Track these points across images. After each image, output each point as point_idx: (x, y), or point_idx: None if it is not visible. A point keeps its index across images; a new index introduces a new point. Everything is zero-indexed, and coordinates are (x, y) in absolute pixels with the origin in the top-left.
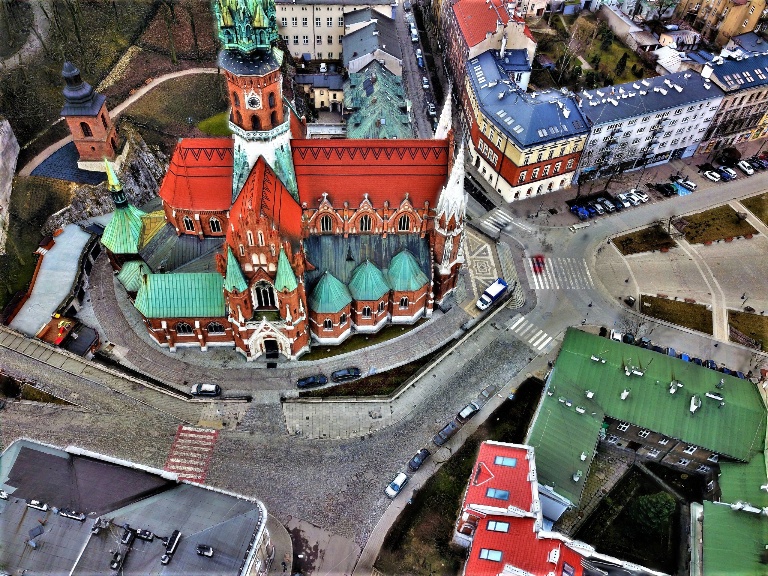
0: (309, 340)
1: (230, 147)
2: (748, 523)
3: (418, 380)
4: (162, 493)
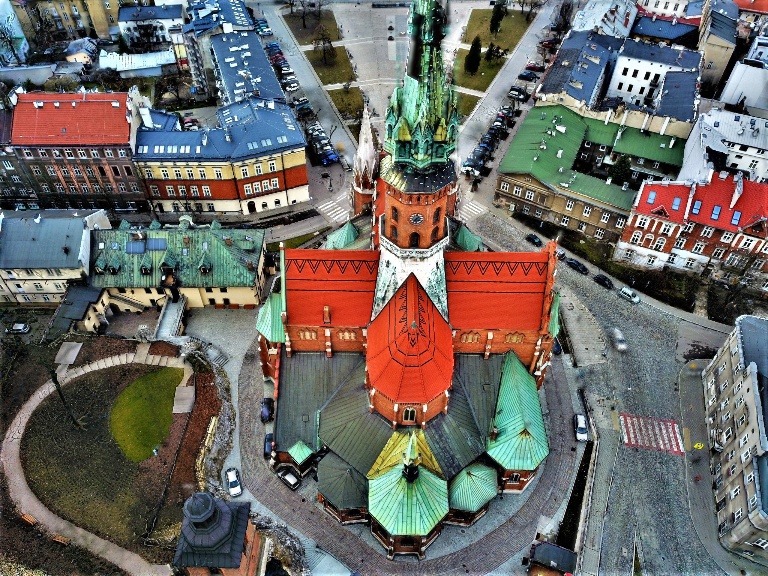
0: None
1: (416, 284)
2: (627, 135)
3: None
4: (765, 376)
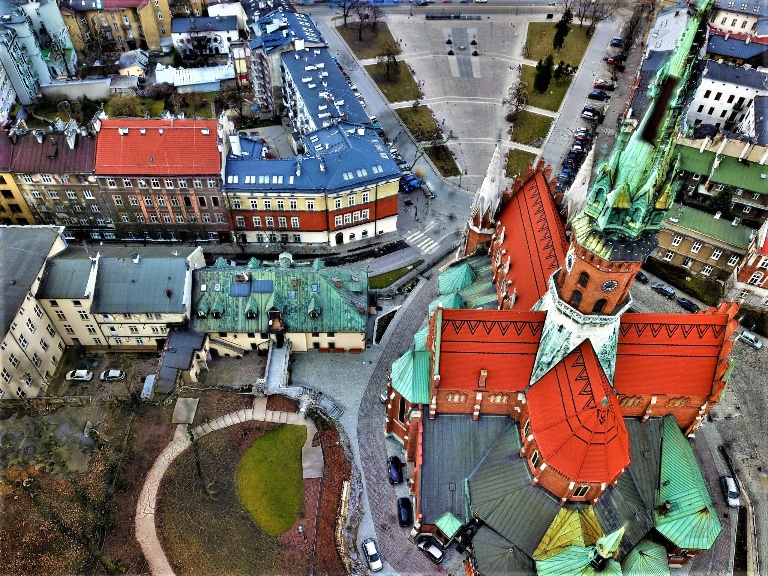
0: None
1: None
2: (725, 164)
3: None
4: None
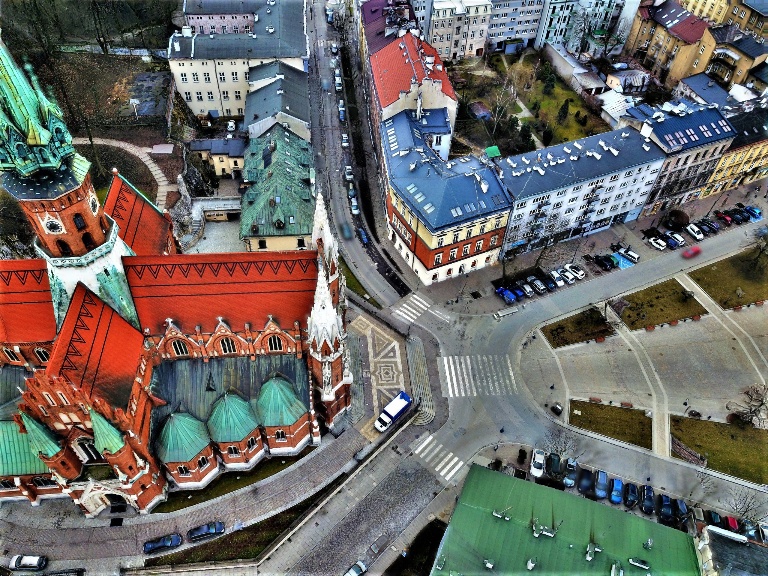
0: (165, 486)
1: None
2: None
3: (296, 532)
4: None
